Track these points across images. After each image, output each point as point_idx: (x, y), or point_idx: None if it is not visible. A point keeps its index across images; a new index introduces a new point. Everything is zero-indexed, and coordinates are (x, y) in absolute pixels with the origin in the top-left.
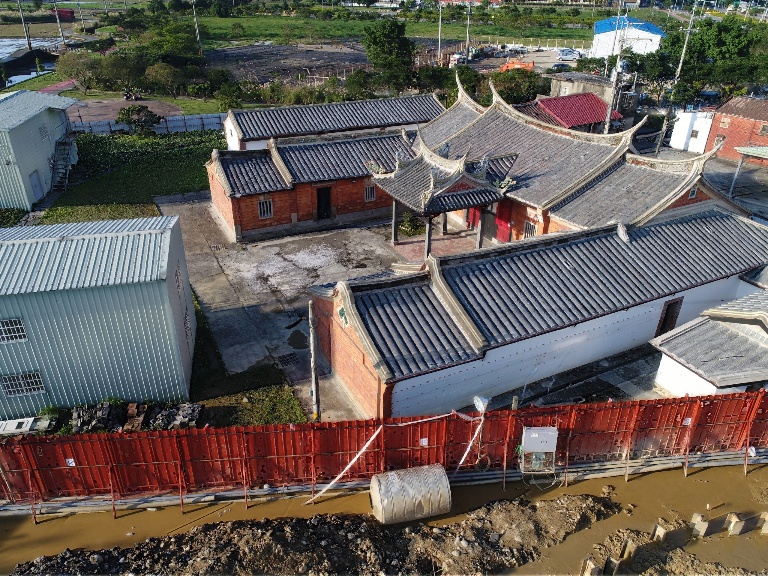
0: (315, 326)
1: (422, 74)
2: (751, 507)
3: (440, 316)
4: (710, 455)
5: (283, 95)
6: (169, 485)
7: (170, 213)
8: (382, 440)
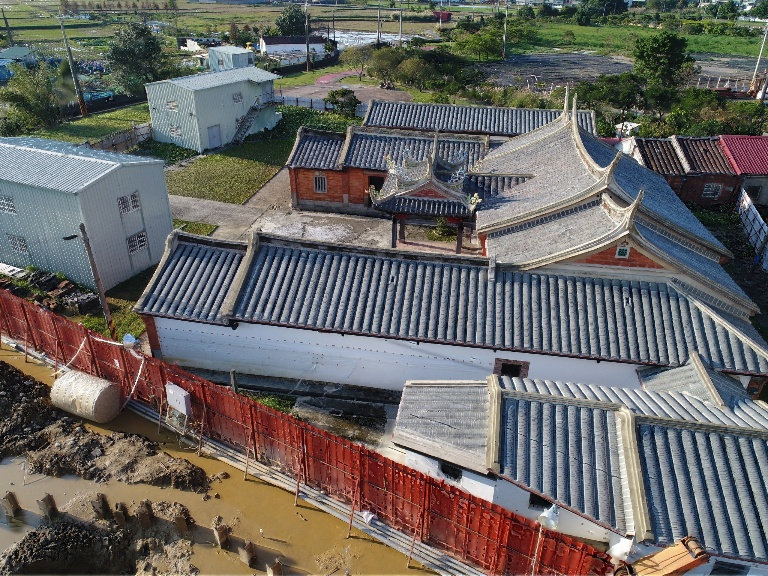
0: (86, 245)
1: (648, 93)
2: (302, 559)
3: (231, 282)
4: (327, 498)
5: (511, 100)
6: (4, 327)
7: (282, 176)
8: (89, 347)
